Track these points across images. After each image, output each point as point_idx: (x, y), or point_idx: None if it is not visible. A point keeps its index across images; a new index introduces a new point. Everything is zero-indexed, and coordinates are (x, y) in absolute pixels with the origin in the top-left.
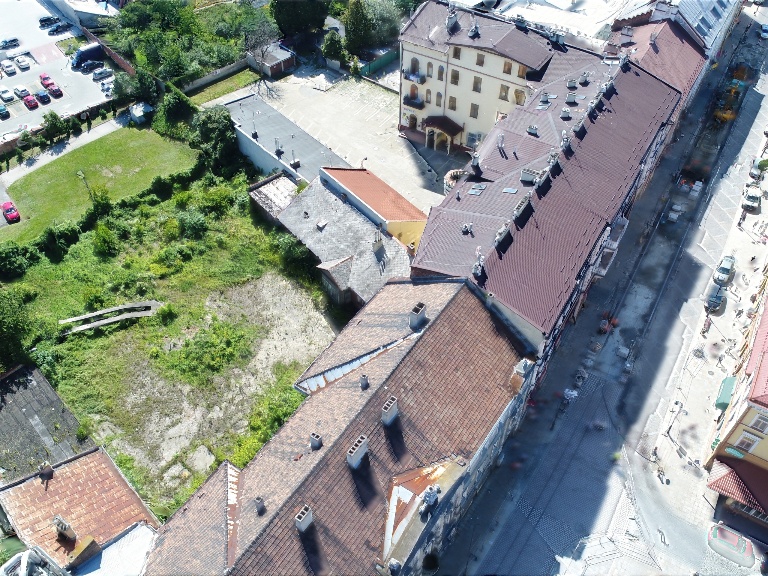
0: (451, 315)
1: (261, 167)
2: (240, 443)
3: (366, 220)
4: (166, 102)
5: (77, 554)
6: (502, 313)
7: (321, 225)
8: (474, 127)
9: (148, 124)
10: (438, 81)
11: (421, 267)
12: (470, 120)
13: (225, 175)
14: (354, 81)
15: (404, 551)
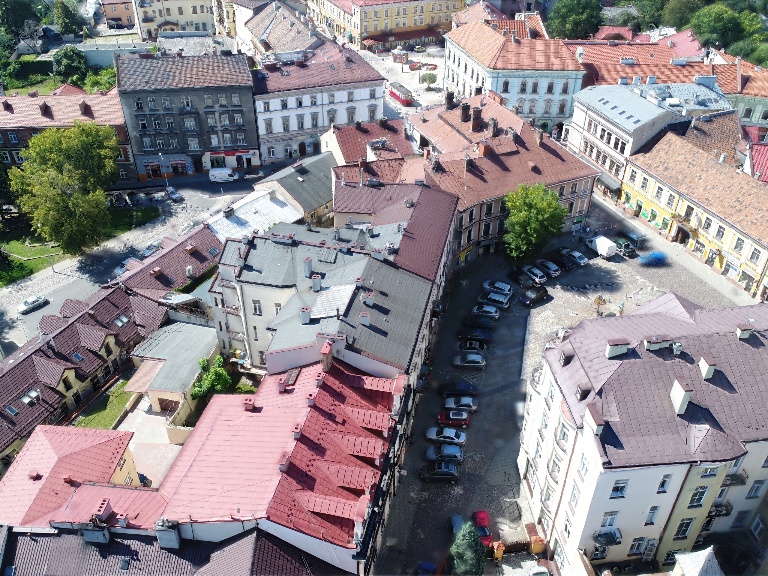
0: (283, 5)
1: (109, 64)
2: None
3: (199, 37)
4: (11, 70)
5: None
6: (291, 6)
7: (182, 48)
8: (183, 20)
9: (4, 89)
10: (158, 3)
11: (257, 6)
12: (180, 17)
13: (95, 74)
14: (91, 39)
15: None
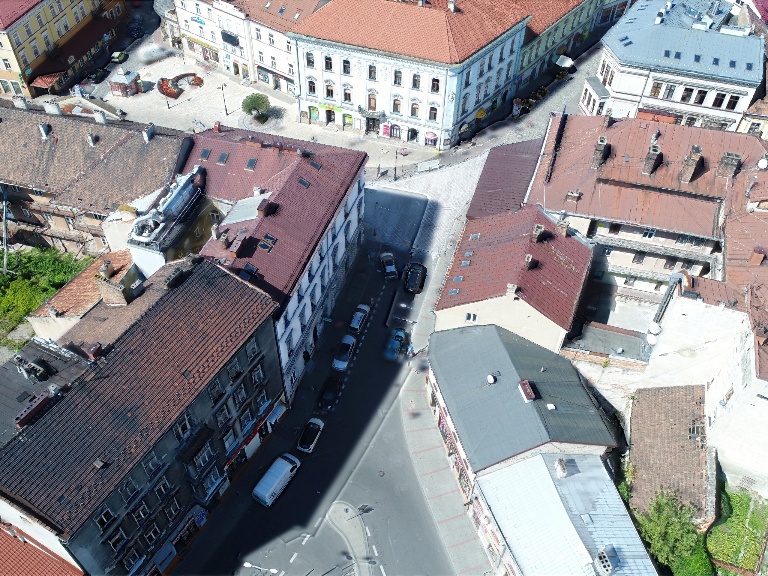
0: None
1: None
2: (7, 309)
3: None
4: None
5: (132, 208)
6: None
7: None
8: None
9: None
10: None
11: None
12: None
13: None
14: None
15: (112, 108)
